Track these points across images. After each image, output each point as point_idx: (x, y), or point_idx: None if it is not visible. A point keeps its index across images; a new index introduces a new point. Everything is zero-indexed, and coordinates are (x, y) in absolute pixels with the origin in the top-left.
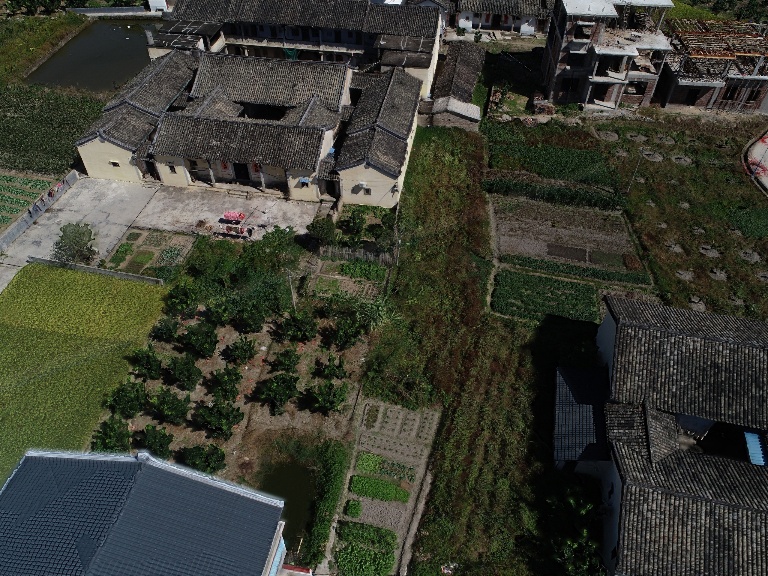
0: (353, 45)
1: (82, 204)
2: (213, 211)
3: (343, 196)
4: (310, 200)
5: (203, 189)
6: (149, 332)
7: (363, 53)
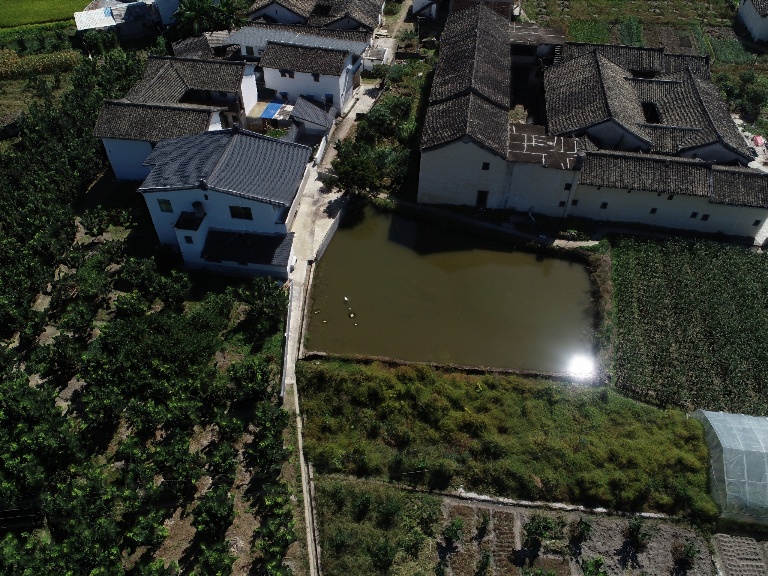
0: None
1: None
2: None
3: None
4: None
5: None
6: None
7: None
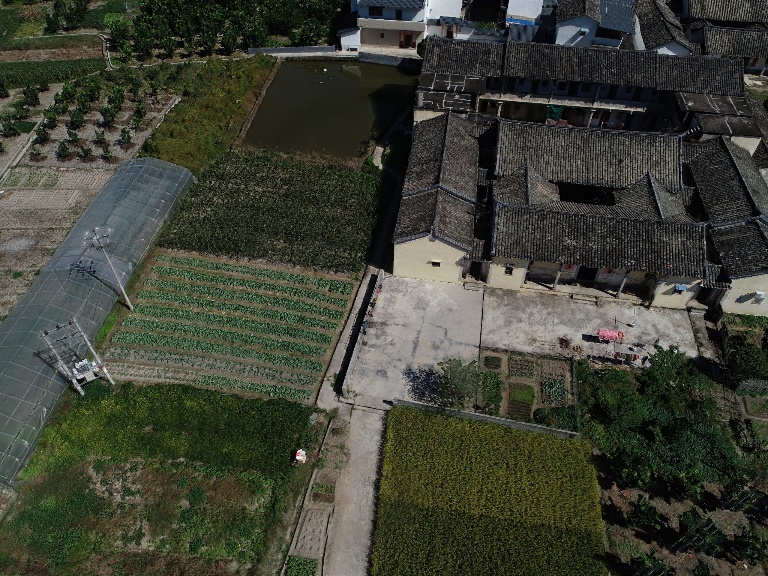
0: (635, 102)
1: (406, 315)
2: (568, 324)
3: (721, 304)
4: (674, 307)
5: (537, 292)
6: (601, 514)
7: (645, 111)
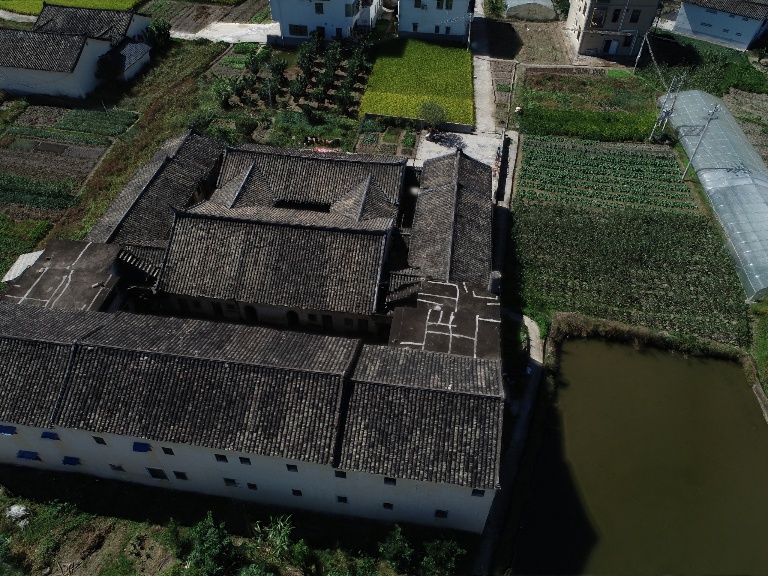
0: None
1: None
2: None
3: None
4: None
5: None
6: None
7: None
